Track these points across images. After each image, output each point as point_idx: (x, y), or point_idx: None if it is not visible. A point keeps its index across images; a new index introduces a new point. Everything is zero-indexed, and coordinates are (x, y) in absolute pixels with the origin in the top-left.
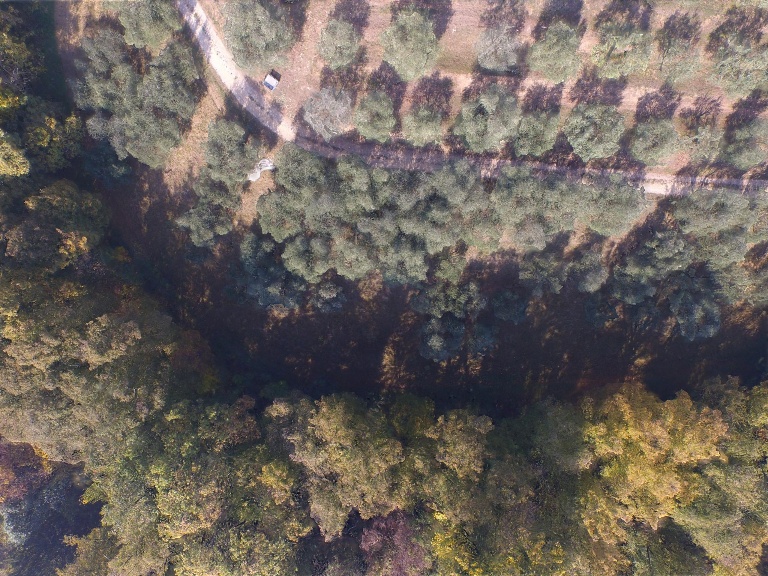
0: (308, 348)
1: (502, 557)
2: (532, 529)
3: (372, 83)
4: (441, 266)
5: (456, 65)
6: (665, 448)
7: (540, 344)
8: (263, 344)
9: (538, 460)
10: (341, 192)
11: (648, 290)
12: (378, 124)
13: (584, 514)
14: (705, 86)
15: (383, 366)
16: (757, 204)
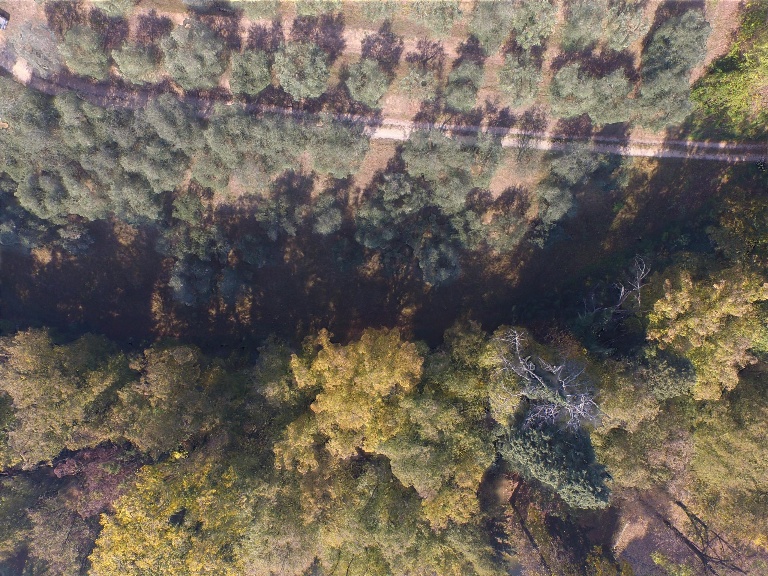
0: (77, 294)
1: (177, 481)
2: (236, 461)
3: (94, 22)
4: (176, 207)
5: (170, 4)
6: (347, 377)
7: (304, 292)
8: (34, 290)
9: None
10: (60, 129)
11: (382, 233)
12: (82, 58)
13: (276, 444)
14: (423, 29)
15: (154, 314)
16: (480, 147)
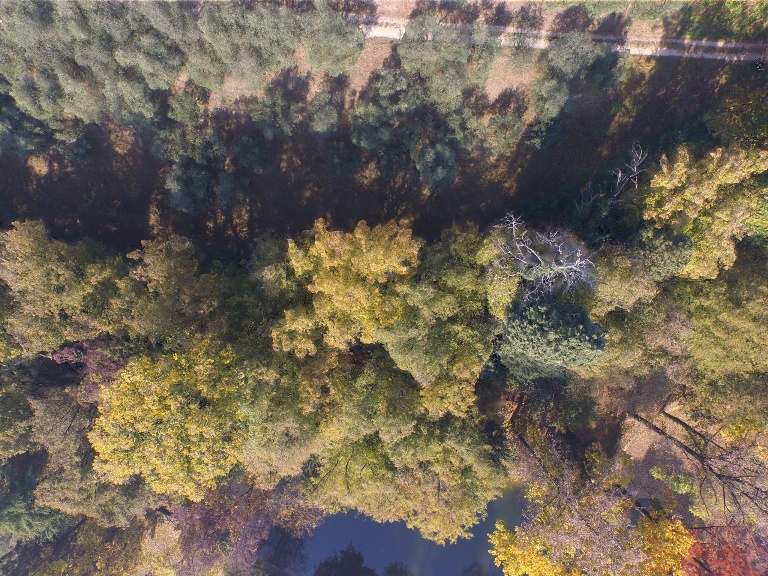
0: (75, 208)
1: (176, 361)
2: None
3: None
4: (172, 107)
5: None
6: (344, 258)
7: (302, 203)
8: (31, 205)
9: (266, 298)
10: (54, 22)
11: (378, 132)
12: None
13: (274, 329)
14: None
15: (151, 227)
16: (476, 40)
